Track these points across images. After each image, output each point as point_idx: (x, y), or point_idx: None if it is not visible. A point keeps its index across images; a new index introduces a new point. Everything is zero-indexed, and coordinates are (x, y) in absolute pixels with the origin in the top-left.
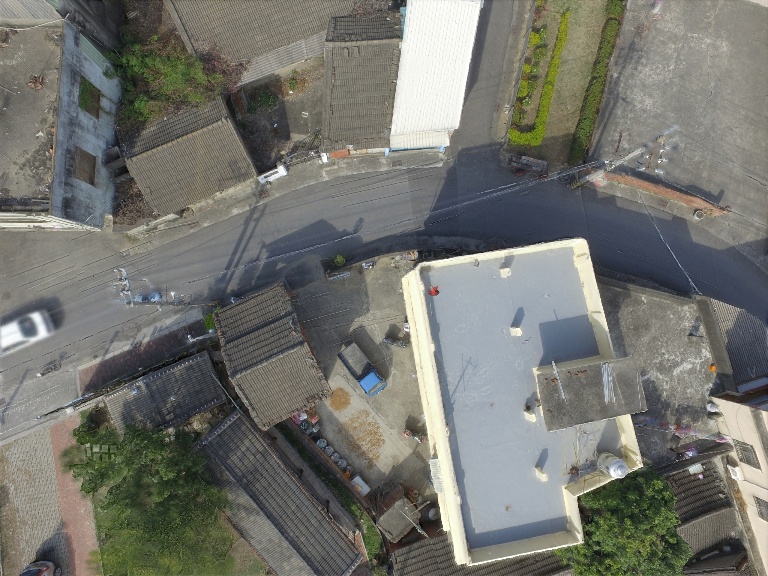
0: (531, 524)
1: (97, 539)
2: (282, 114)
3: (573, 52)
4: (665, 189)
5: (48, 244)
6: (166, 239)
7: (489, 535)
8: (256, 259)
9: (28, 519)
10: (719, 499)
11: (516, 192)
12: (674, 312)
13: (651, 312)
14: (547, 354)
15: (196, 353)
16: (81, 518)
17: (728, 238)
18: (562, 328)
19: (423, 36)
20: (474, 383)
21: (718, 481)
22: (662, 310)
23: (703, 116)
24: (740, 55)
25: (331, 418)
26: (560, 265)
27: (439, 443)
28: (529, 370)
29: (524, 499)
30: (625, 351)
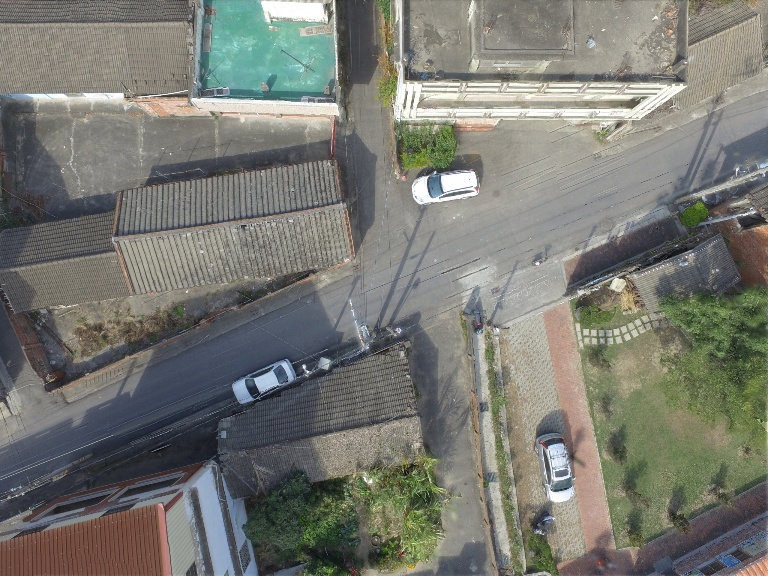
0: None
1: (590, 416)
2: None
3: None
4: None
5: (531, 146)
6: (634, 142)
7: None
8: (715, 160)
9: (528, 397)
10: None
11: None
12: None
13: None
14: None
15: (715, 235)
16: (575, 397)
17: None
18: None
19: None
20: None
21: None
22: None
23: None
24: None
25: None
26: None
27: None
28: None
29: None
30: None
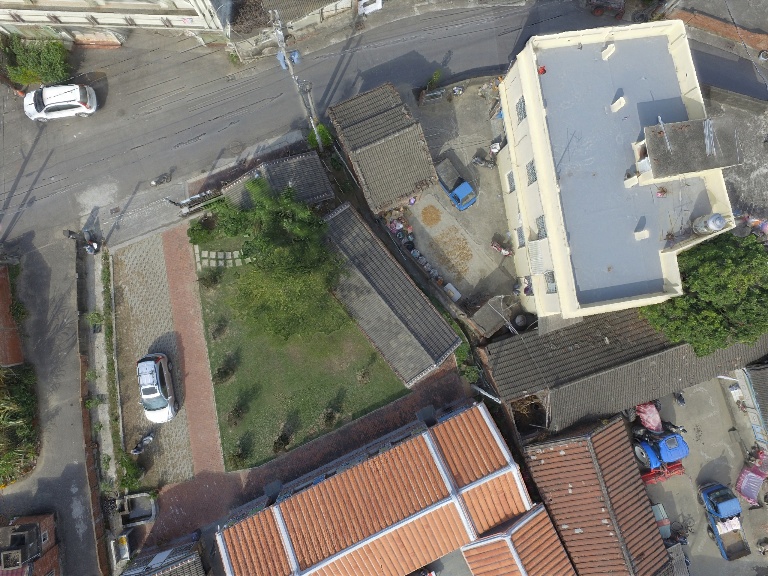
0: (630, 284)
1: (205, 338)
2: None
3: None
4: (734, 27)
5: (160, 66)
6: (269, 65)
7: (592, 292)
8: (352, 86)
9: (141, 318)
10: None
11: None
12: (751, 121)
13: None
14: None
15: (307, 151)
16: (190, 319)
17: None
18: (658, 108)
19: None
20: (578, 154)
21: None
22: (740, 118)
23: None
24: None
25: (423, 233)
26: (656, 51)
27: (546, 208)
28: (628, 144)
29: (624, 261)
30: None
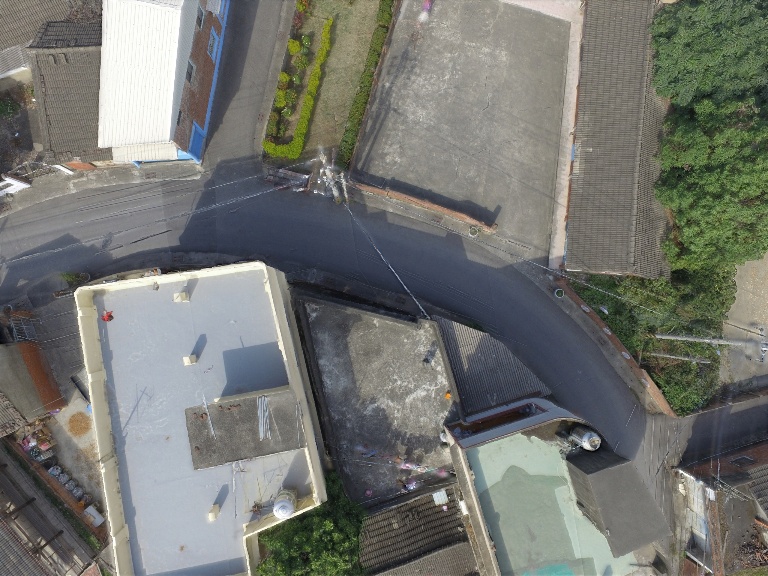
0: (208, 565)
1: None
2: (24, 123)
3: (342, 60)
4: (432, 205)
5: None
6: None
7: None
8: None
9: None
10: (457, 532)
11: (279, 206)
12: (408, 336)
13: (383, 336)
14: (231, 384)
15: None
16: None
17: (505, 256)
18: (248, 356)
19: (123, 43)
20: (149, 414)
21: (459, 513)
22: (395, 334)
23: (479, 128)
24: (520, 65)
25: (70, 443)
26: (248, 289)
27: None
28: (210, 401)
29: (201, 538)
30: (353, 377)
